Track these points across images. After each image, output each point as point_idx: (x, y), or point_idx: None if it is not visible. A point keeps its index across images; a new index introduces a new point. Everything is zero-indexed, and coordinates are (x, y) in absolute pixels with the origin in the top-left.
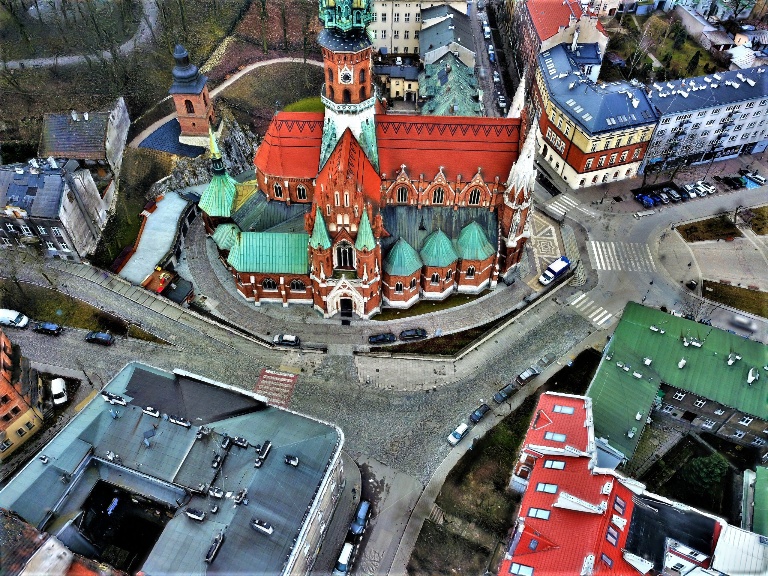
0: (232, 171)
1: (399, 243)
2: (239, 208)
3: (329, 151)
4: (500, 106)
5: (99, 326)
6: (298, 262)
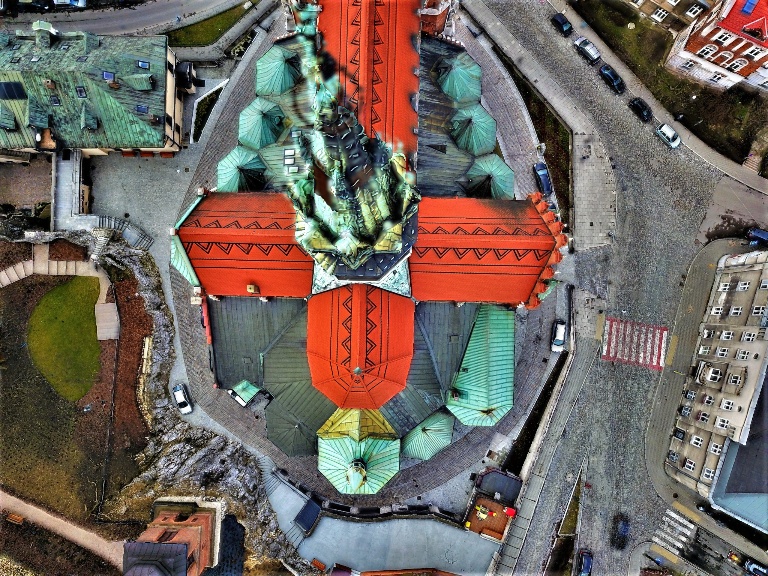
0: (239, 465)
1: (494, 180)
2: (392, 428)
3: (408, 276)
4: (1, 9)
5: (566, 575)
6: (506, 324)
